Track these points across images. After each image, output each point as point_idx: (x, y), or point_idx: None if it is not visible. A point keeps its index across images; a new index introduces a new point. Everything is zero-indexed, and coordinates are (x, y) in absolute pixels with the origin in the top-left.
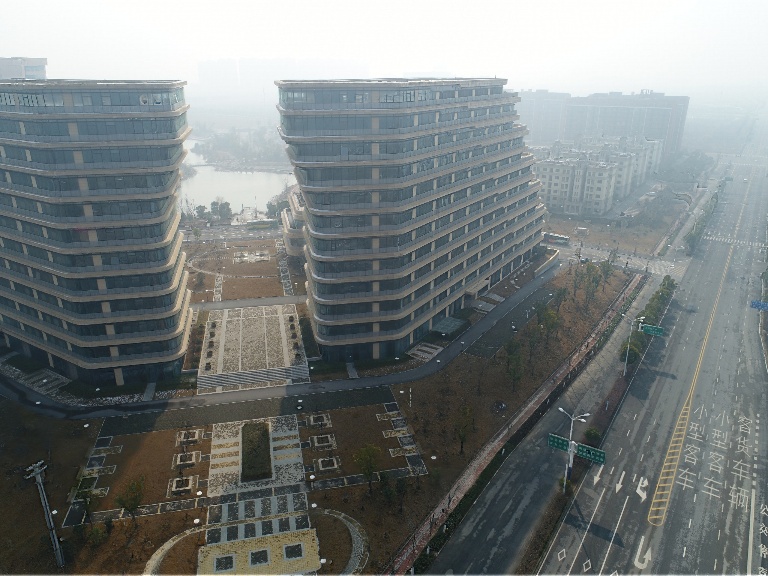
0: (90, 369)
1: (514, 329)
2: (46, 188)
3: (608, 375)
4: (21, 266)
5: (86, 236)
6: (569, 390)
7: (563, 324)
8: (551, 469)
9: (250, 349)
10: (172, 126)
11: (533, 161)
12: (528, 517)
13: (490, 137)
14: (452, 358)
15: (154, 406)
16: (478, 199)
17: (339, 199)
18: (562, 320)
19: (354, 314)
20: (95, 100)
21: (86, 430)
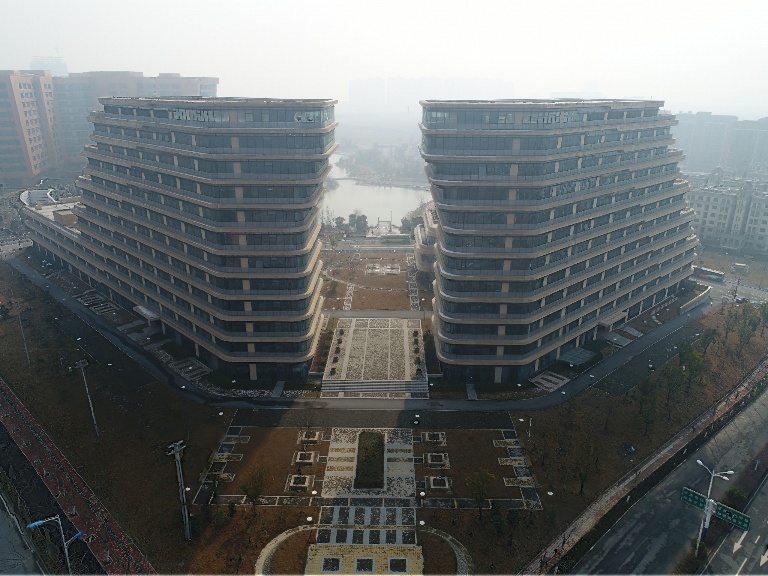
0: (229, 362)
1: (651, 368)
2: (208, 194)
3: (760, 431)
4: (181, 263)
5: (237, 240)
6: (711, 442)
7: (709, 368)
8: (683, 526)
9: (373, 359)
10: (321, 142)
11: (687, 189)
12: (651, 575)
13: (640, 161)
14: (579, 391)
15: (281, 403)
16: (621, 226)
17: (473, 218)
18: (709, 364)
19: (479, 335)
20: (256, 117)
21: (221, 418)
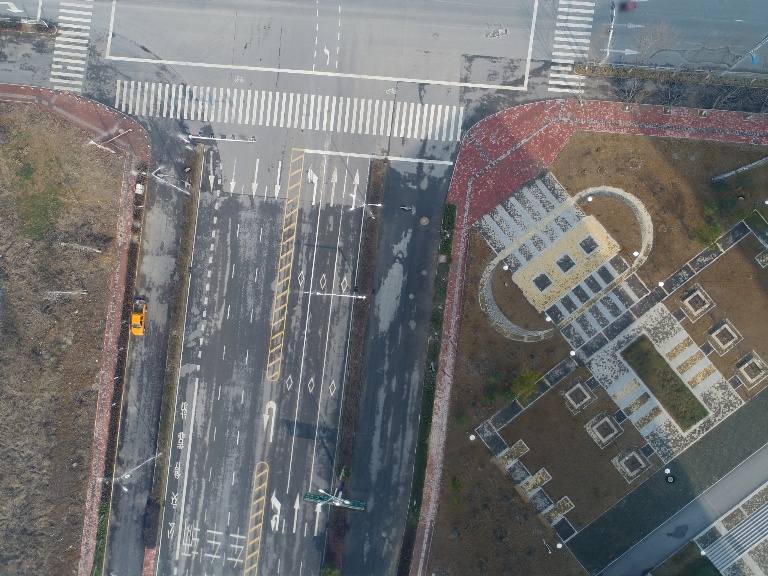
0: None
1: None
2: None
3: None
4: None
5: None
6: None
7: None
8: None
9: None
10: None
11: None
12: (369, 420)
13: None
14: None
15: None
16: None
17: None
18: None
19: None
20: None
21: None
